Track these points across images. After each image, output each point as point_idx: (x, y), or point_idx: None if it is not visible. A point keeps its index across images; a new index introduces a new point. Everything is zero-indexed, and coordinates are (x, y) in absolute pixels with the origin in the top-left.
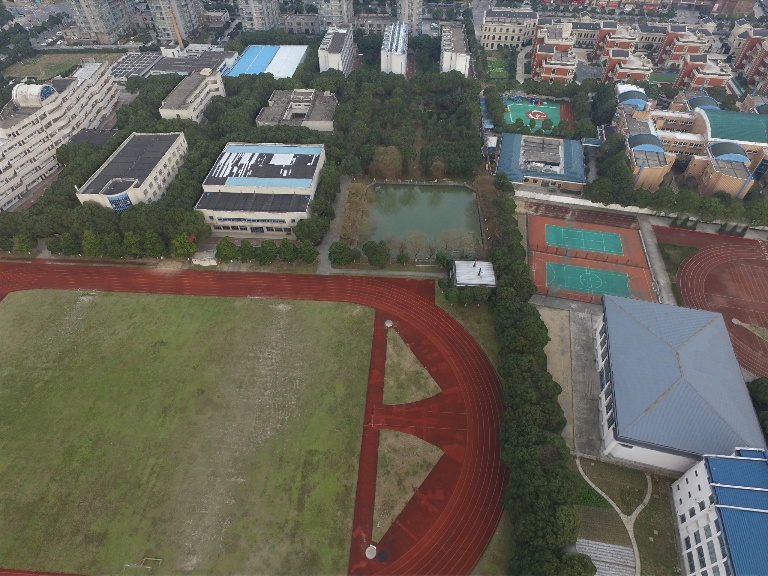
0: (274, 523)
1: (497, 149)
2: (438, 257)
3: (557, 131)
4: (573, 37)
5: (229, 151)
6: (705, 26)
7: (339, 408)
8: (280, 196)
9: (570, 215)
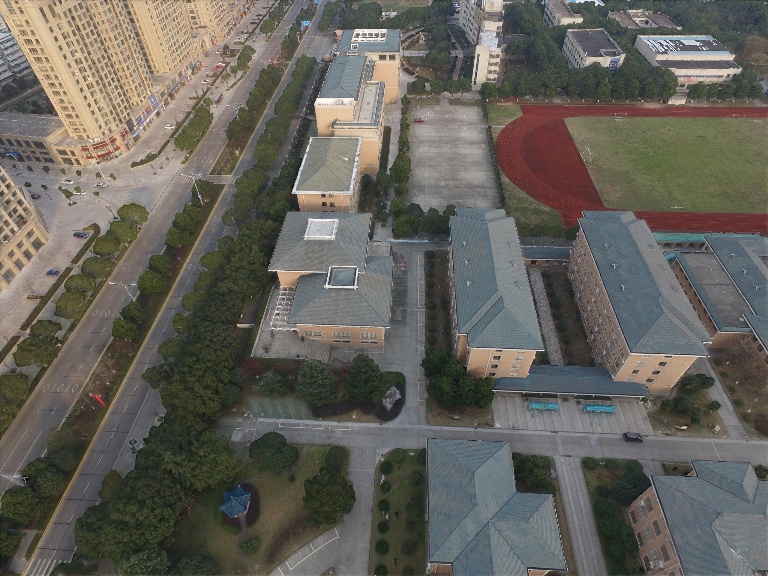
0: None
1: None
2: None
3: None
4: None
5: (645, 39)
6: None
7: None
8: (711, 62)
9: None
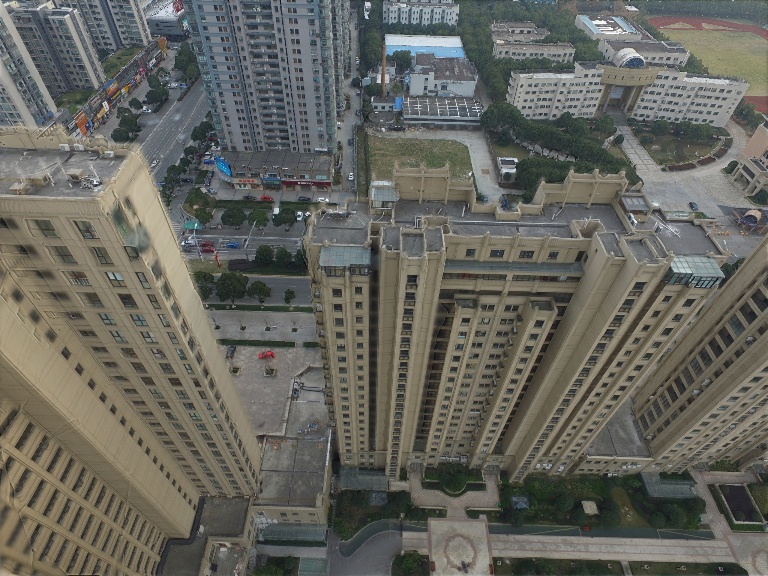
0: None
1: None
2: None
3: None
4: None
5: None
6: None
7: None
8: None
9: None
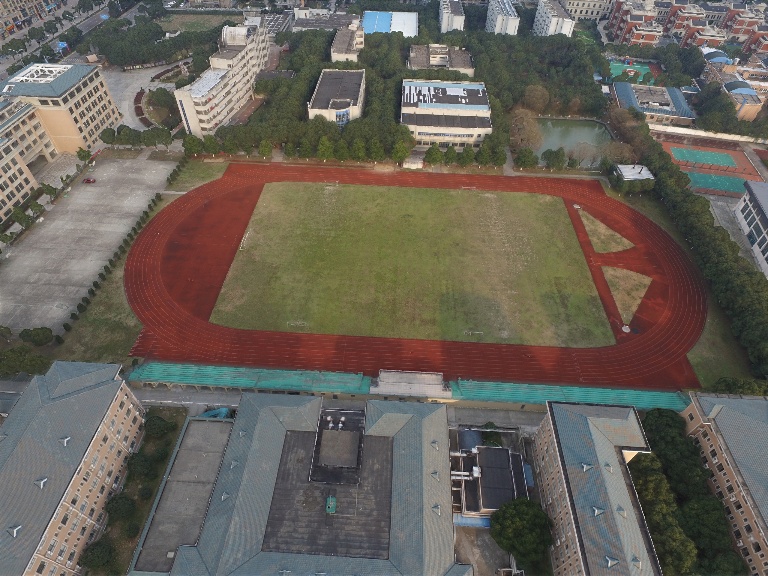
0: (551, 314)
1: (610, 95)
2: (603, 162)
3: (659, 81)
4: (655, 10)
5: (407, 85)
6: (757, 6)
7: (565, 254)
8: (465, 117)
9: (686, 141)
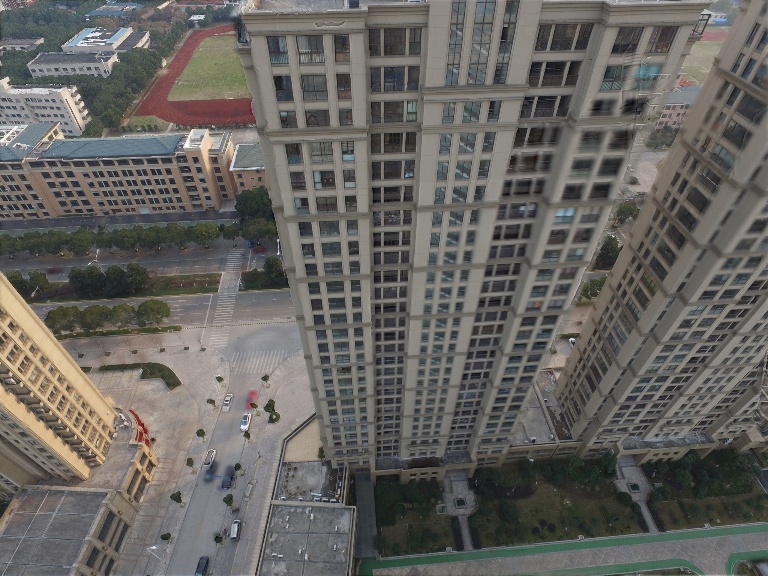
0: None
1: None
2: (186, 21)
3: None
4: None
5: None
6: None
7: None
8: None
9: None
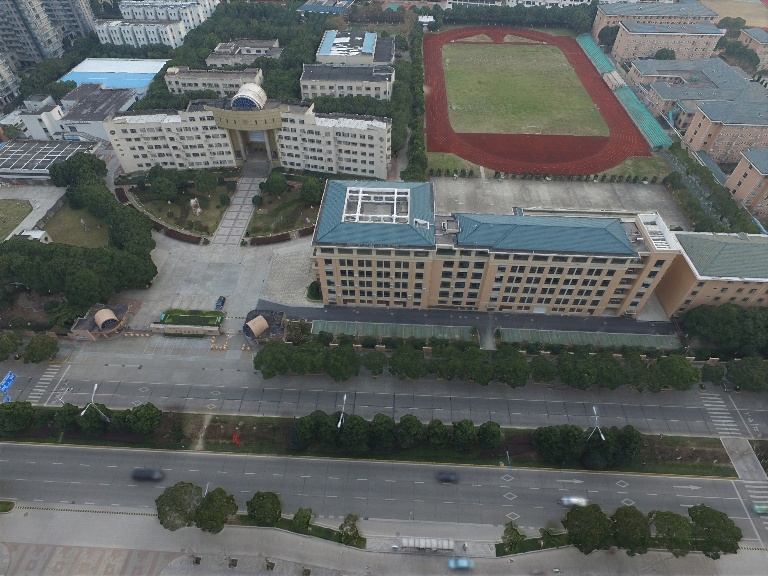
0: None
1: None
2: (417, 23)
3: None
4: None
5: None
6: None
7: None
8: None
9: None
